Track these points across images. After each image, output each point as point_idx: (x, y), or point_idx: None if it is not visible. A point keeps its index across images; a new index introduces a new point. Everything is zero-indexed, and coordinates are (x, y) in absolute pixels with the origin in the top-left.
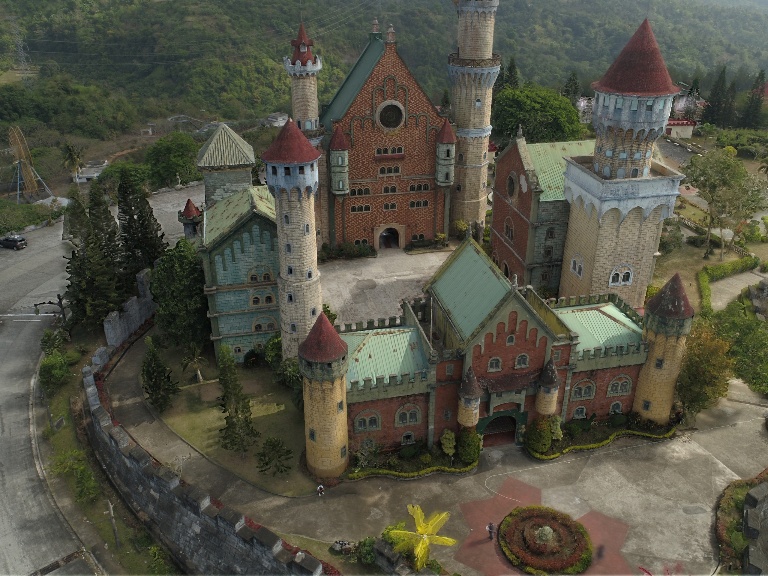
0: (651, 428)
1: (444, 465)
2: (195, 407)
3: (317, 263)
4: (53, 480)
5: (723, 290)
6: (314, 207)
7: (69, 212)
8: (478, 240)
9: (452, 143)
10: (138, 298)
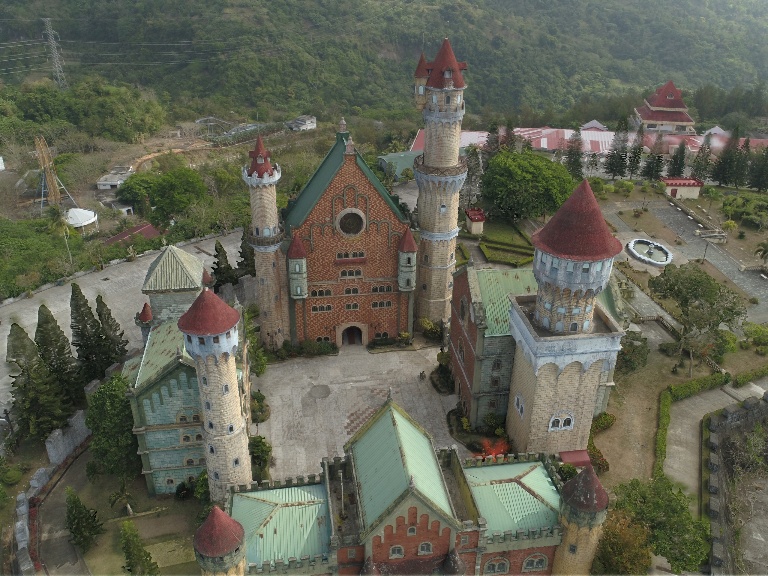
0: None
1: None
2: (119, 547)
3: (276, 361)
4: None
5: (686, 413)
6: (274, 307)
7: (12, 338)
8: (443, 339)
9: (413, 252)
10: (86, 409)
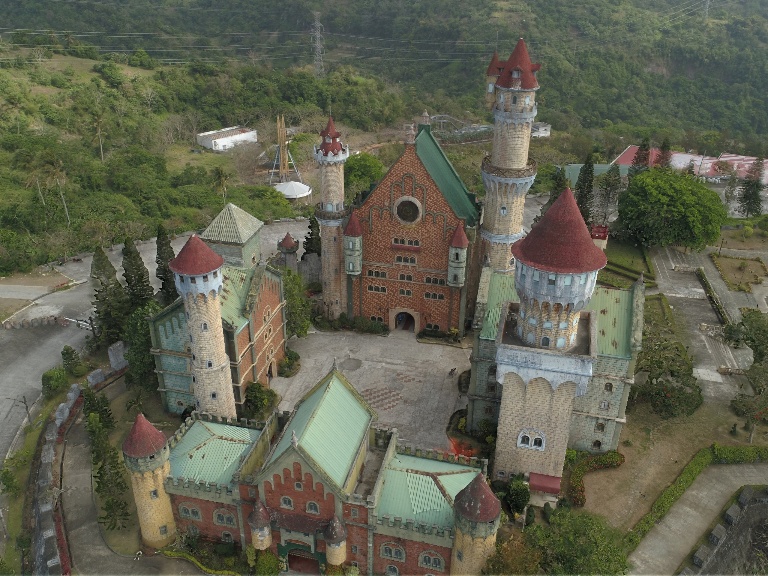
0: None
1: (243, 573)
2: None
3: (330, 330)
4: (9, 469)
5: (725, 478)
6: (333, 279)
7: (95, 258)
8: None
9: (461, 248)
10: None
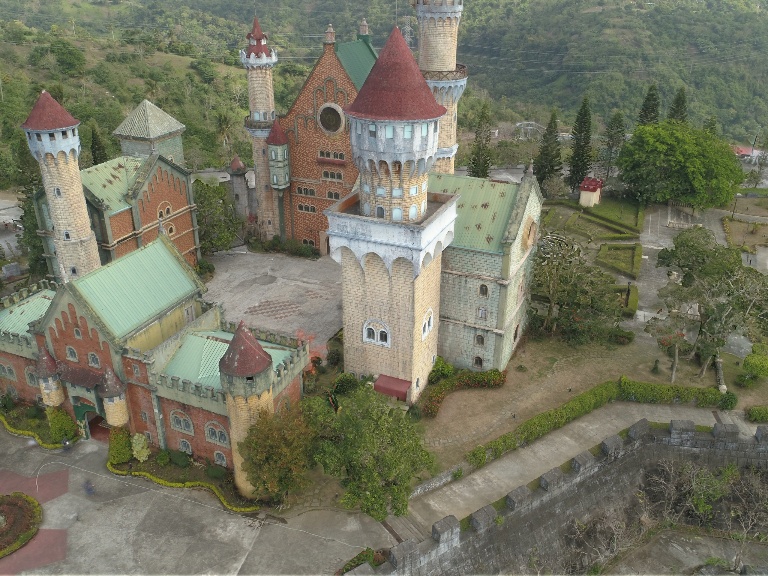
0: None
1: (44, 435)
2: None
3: (260, 251)
4: None
5: (628, 415)
6: (264, 197)
7: (19, 151)
8: None
9: None
10: None
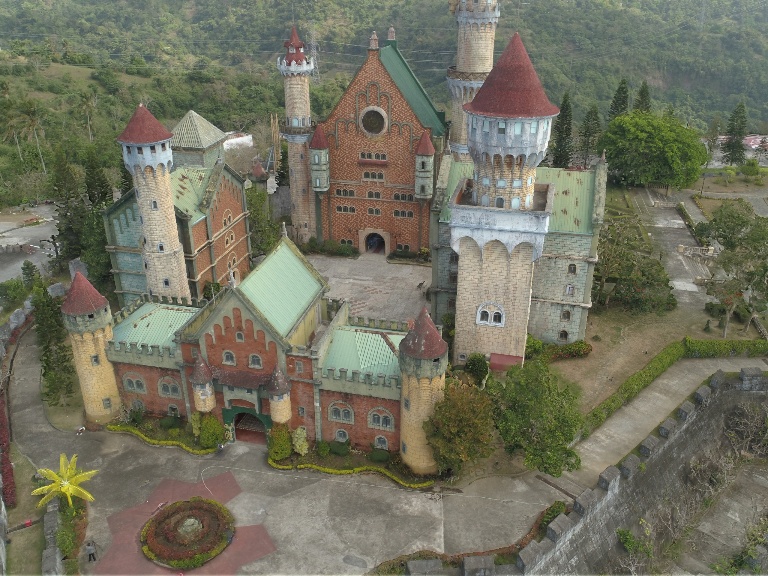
0: (404, 473)
1: (188, 443)
2: None
3: None
4: None
5: (697, 370)
6: (301, 201)
7: (55, 169)
8: None
9: (427, 155)
10: None
